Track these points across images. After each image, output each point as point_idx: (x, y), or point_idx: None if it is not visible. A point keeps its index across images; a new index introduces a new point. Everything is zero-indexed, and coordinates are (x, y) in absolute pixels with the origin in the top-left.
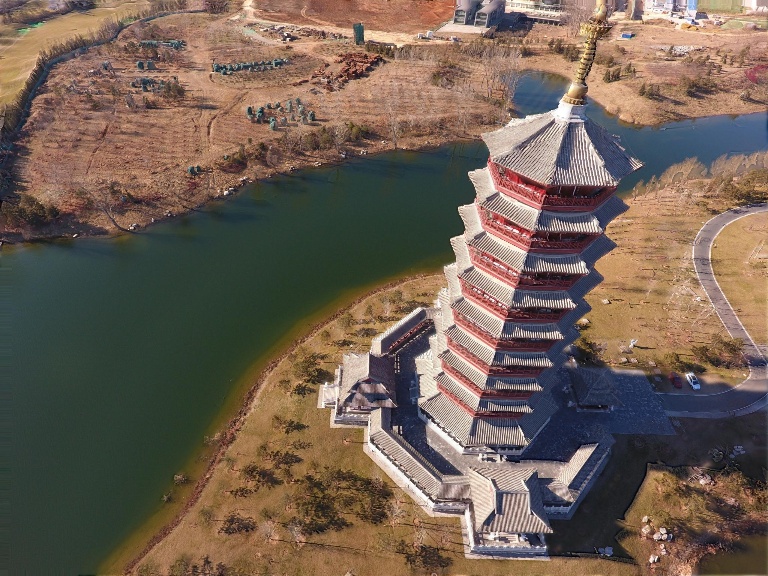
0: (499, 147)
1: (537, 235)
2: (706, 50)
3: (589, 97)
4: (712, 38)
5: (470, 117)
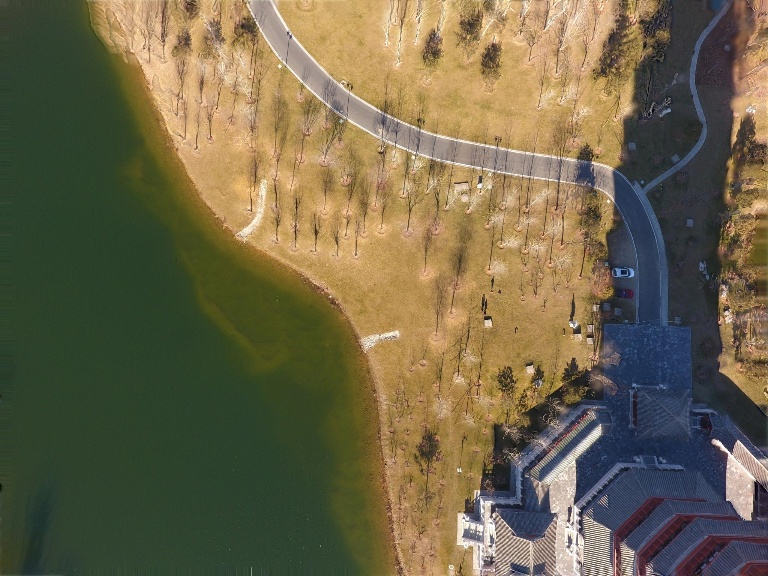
0: None
1: None
2: None
3: None
4: None
5: None
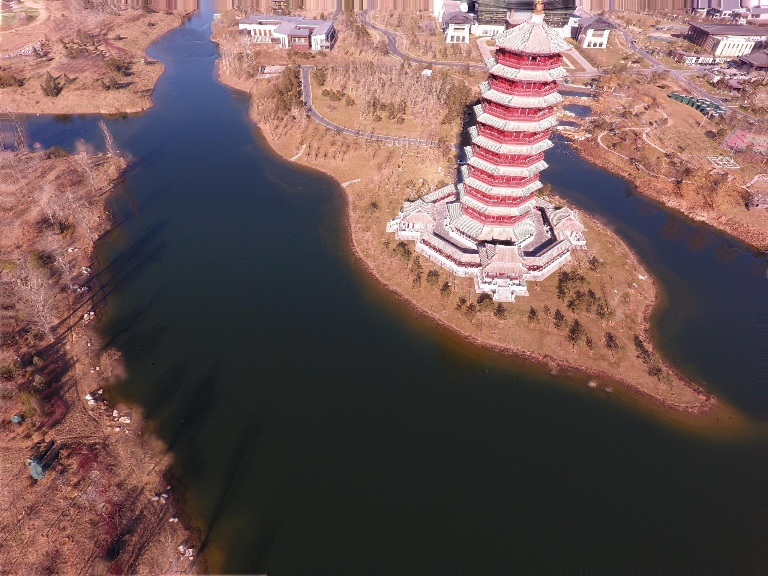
0: (542, 48)
1: (554, 82)
2: (46, 43)
3: (67, 114)
4: (22, 33)
5: (68, 177)
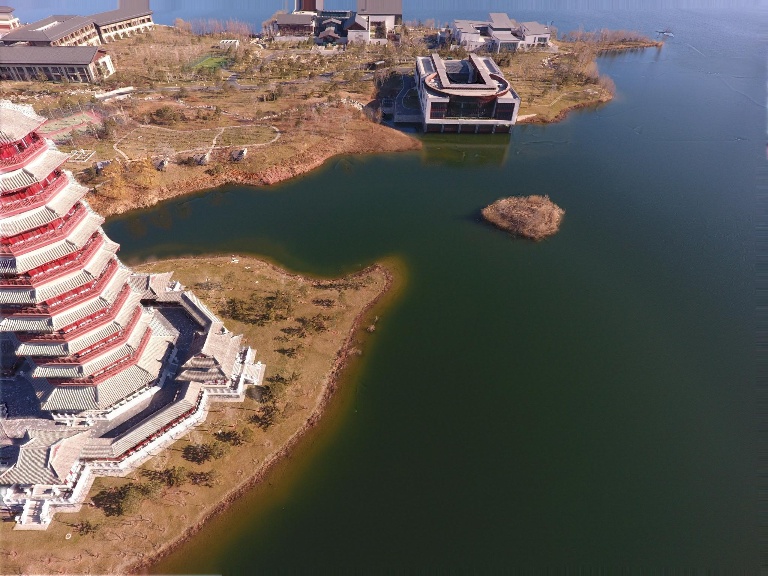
0: (25, 124)
1: None
2: None
3: None
4: None
5: None
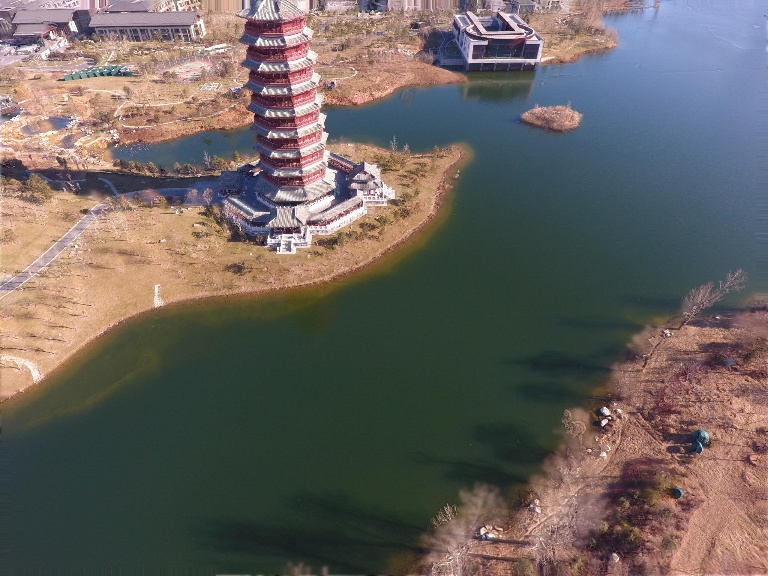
0: (303, 8)
1: None
2: None
3: None
4: None
5: None
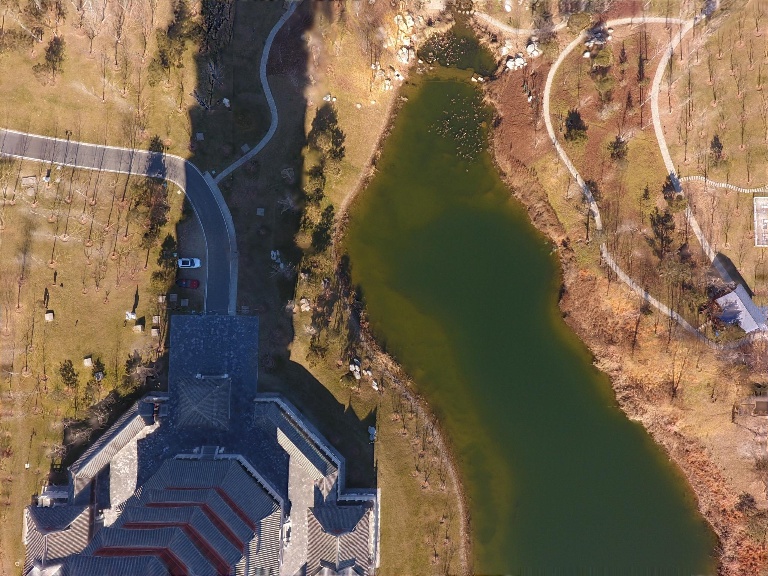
0: None
1: None
2: None
3: None
4: None
5: None
